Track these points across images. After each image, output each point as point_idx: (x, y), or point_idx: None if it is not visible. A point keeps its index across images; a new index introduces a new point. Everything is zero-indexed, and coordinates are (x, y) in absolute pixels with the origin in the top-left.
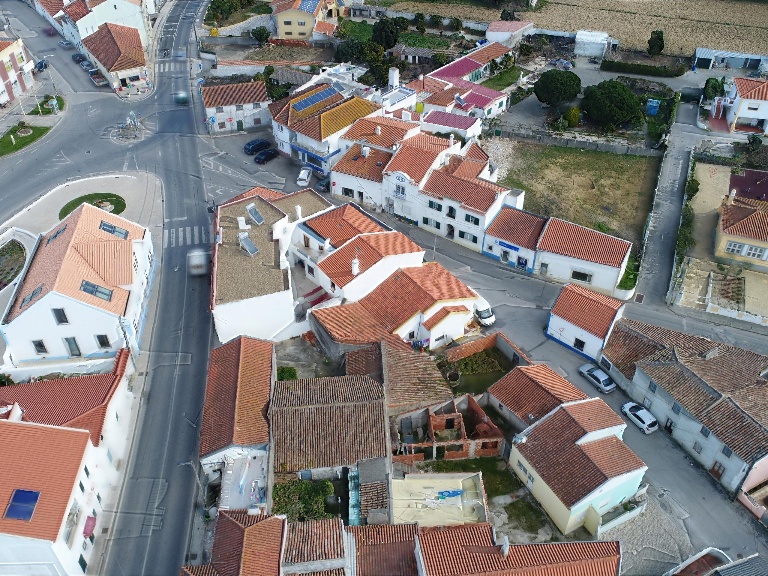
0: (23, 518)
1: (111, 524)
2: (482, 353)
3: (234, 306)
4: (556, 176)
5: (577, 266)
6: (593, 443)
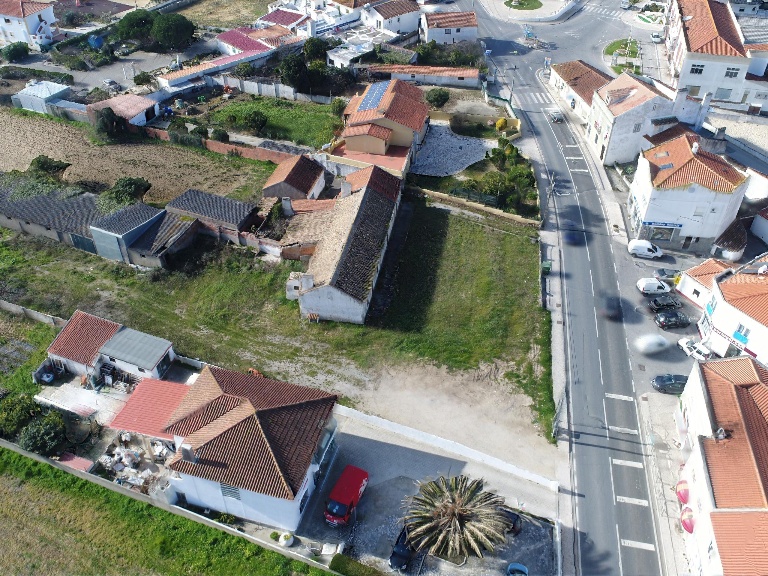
0: None
1: None
2: None
3: None
4: (228, 17)
5: None
6: None
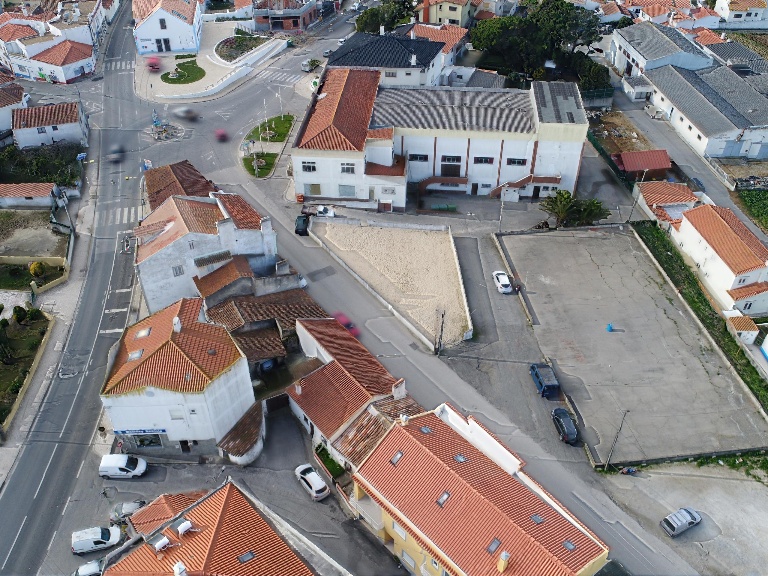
0: None
1: None
2: None
3: None
4: None
5: None
6: None
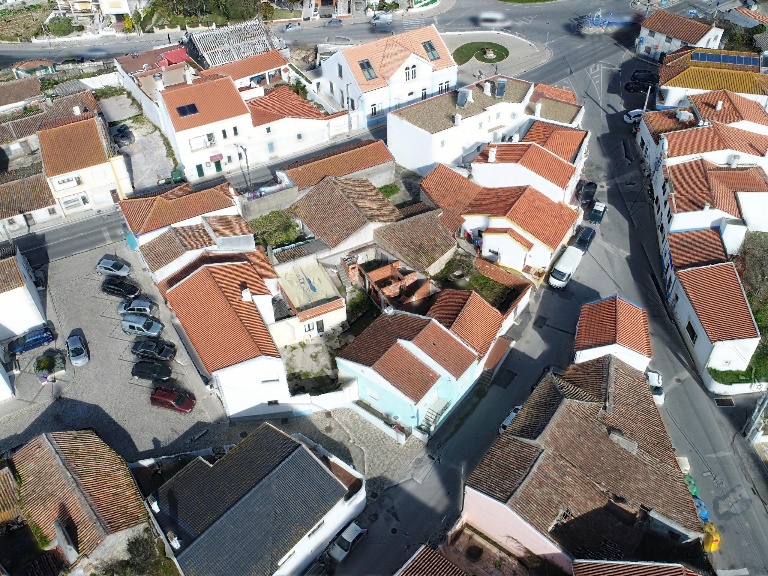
0: (180, 114)
1: (234, 173)
2: (509, 289)
3: (399, 121)
4: None
5: (692, 316)
6: (411, 355)
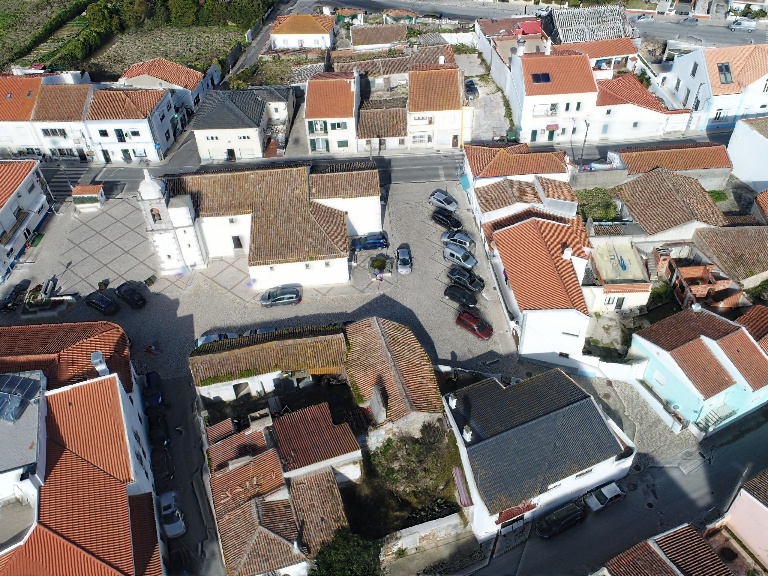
0: (534, 80)
1: (564, 145)
2: None
3: (748, 130)
4: None
5: None
6: (711, 353)
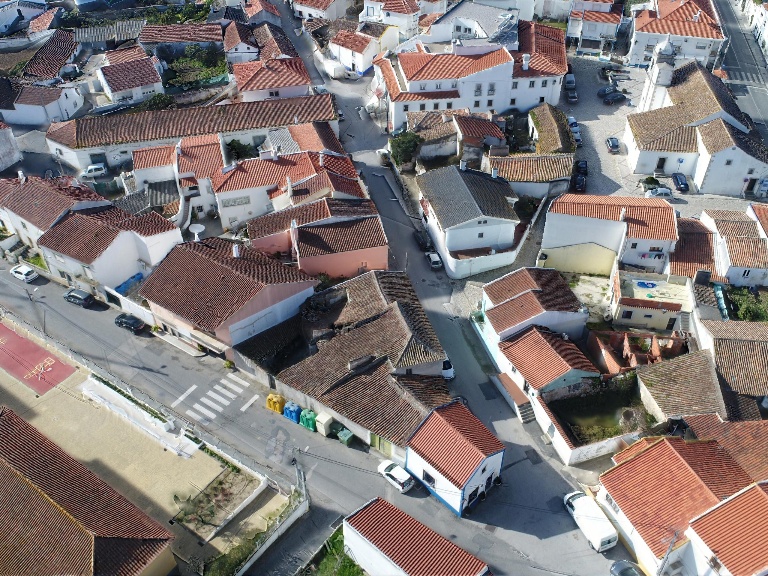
0: None
1: None
2: None
3: None
4: None
5: None
6: None
